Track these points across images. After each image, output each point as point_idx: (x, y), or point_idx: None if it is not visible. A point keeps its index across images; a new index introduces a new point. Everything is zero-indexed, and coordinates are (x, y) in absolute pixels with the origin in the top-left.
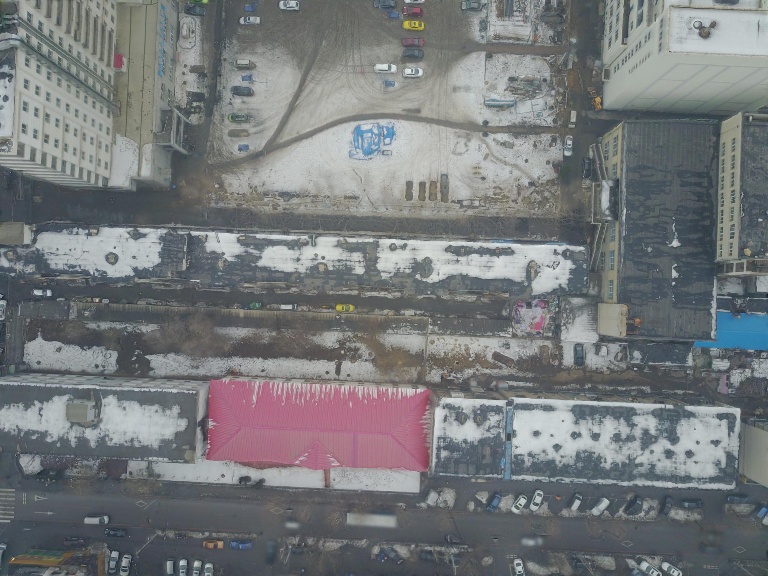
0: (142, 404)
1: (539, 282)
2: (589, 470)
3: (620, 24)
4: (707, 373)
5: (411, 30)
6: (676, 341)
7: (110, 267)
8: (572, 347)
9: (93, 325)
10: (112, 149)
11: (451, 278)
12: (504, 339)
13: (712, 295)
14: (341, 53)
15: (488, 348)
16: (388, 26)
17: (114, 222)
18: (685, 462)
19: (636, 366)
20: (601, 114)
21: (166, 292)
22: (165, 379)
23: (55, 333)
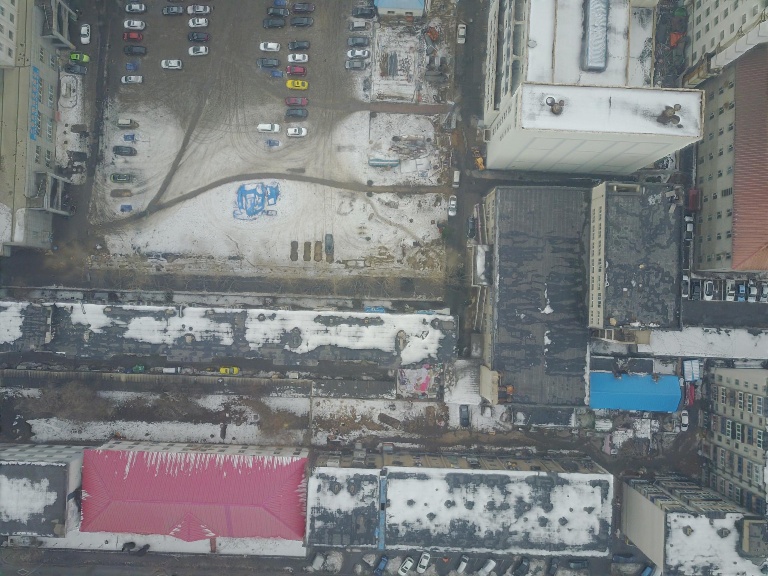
0: (10, 478)
1: (408, 352)
2: (463, 539)
3: (492, 90)
4: (591, 433)
5: (295, 89)
6: None
7: None
8: (458, 408)
9: None
10: None
11: (320, 348)
12: (389, 401)
13: (585, 361)
14: (225, 112)
15: (374, 409)
16: (272, 85)
17: None
18: (559, 529)
19: (521, 426)
20: (485, 173)
21: (48, 355)
22: (46, 445)
23: None
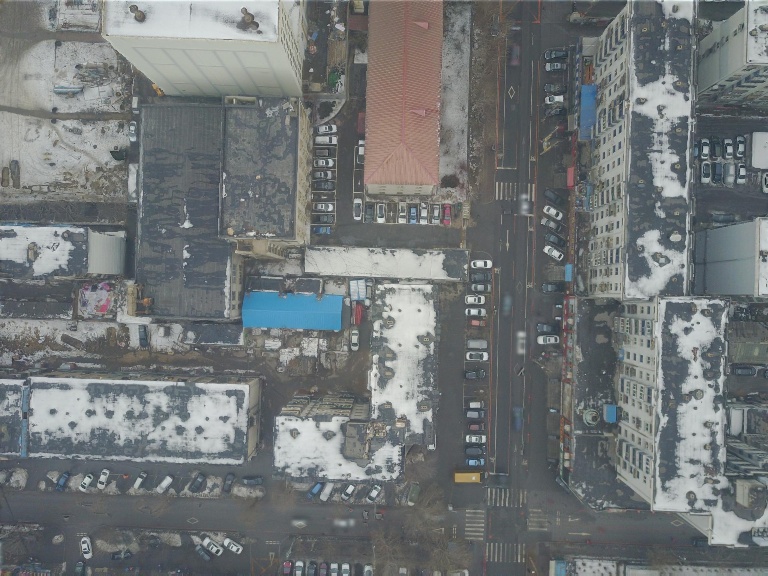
0: None
1: (40, 263)
2: (103, 447)
3: None
4: (265, 353)
5: None
6: (227, 321)
7: None
8: (137, 329)
9: None
10: None
11: None
12: (70, 321)
13: (225, 275)
14: None
15: (57, 331)
16: None
17: None
18: (195, 438)
19: (197, 346)
20: (166, 100)
21: None
22: None
23: None
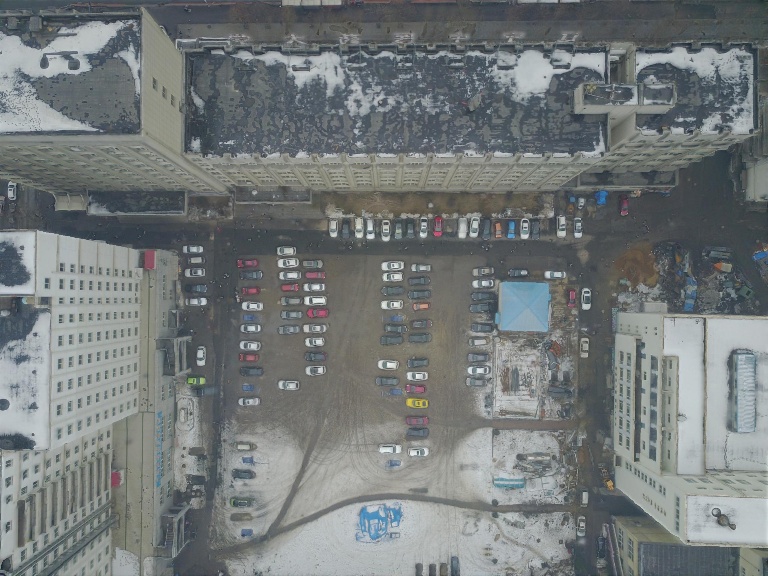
0: None
1: None
2: None
3: (632, 439)
4: None
5: (415, 408)
6: None
7: None
8: None
9: None
10: (112, 564)
11: None
12: None
13: None
14: (344, 432)
15: None
16: (391, 403)
17: None
18: None
19: None
20: (613, 491)
21: None
22: None
23: None
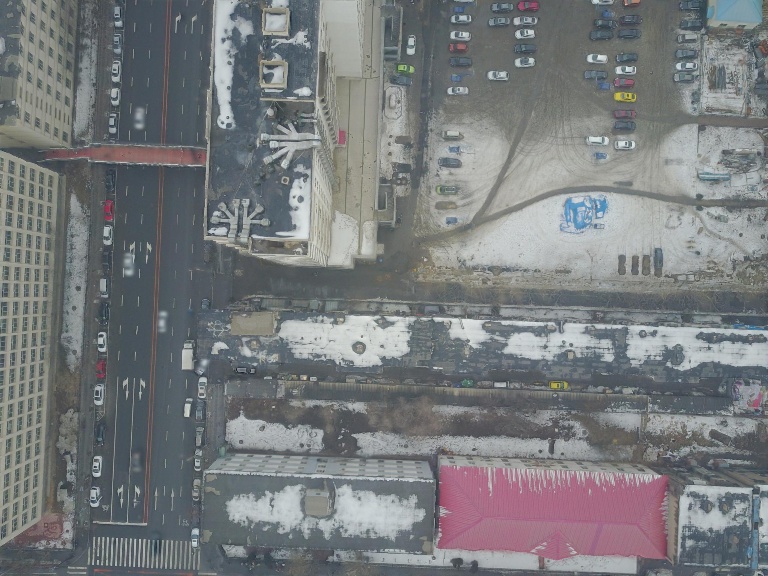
0: (378, 494)
1: None
2: None
3: None
4: None
5: (623, 102)
6: None
7: (357, 357)
8: None
9: (298, 403)
10: (331, 226)
11: (702, 366)
12: (723, 417)
13: None
14: (551, 124)
15: (705, 426)
16: (598, 97)
17: (318, 296)
18: None
19: None
20: None
21: None
22: (375, 459)
23: (258, 411)
